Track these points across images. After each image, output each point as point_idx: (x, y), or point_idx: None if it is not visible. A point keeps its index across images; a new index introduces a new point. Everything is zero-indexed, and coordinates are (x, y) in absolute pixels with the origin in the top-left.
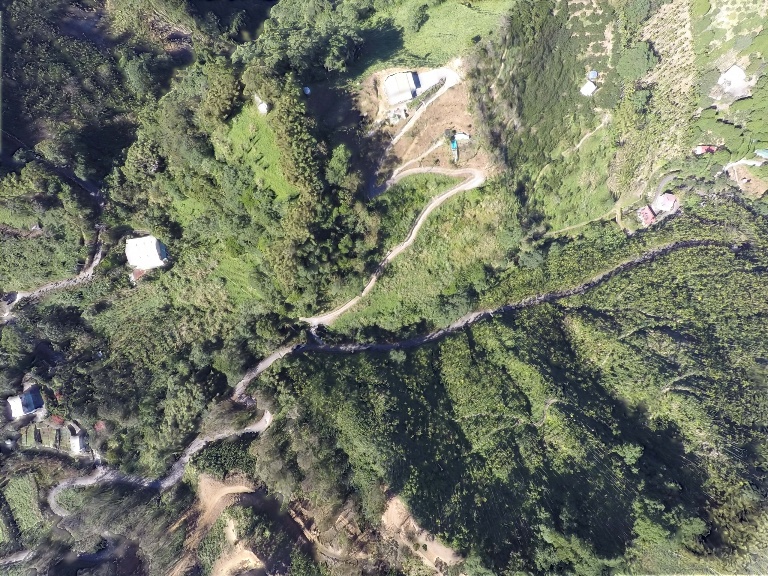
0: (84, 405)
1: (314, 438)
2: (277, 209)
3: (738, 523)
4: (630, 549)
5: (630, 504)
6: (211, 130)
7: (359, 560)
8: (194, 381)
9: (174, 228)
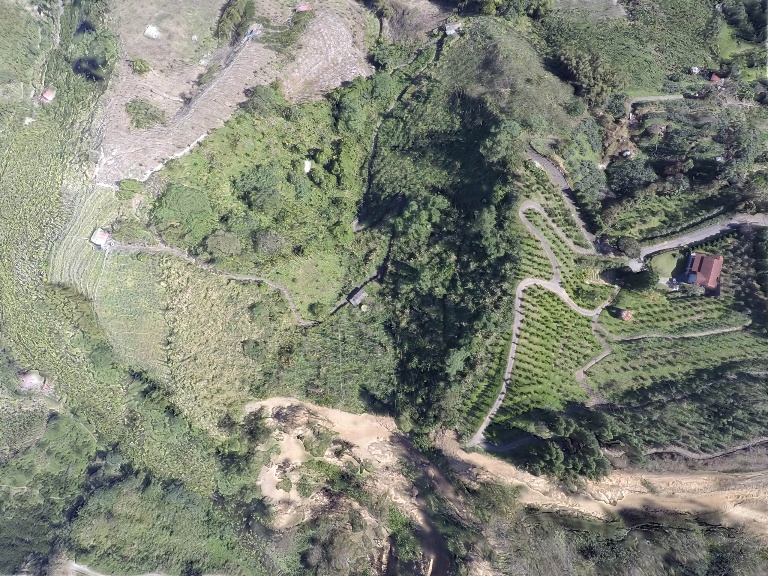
0: None
1: None
2: None
3: None
4: None
5: None
6: None
7: None
8: None
9: None
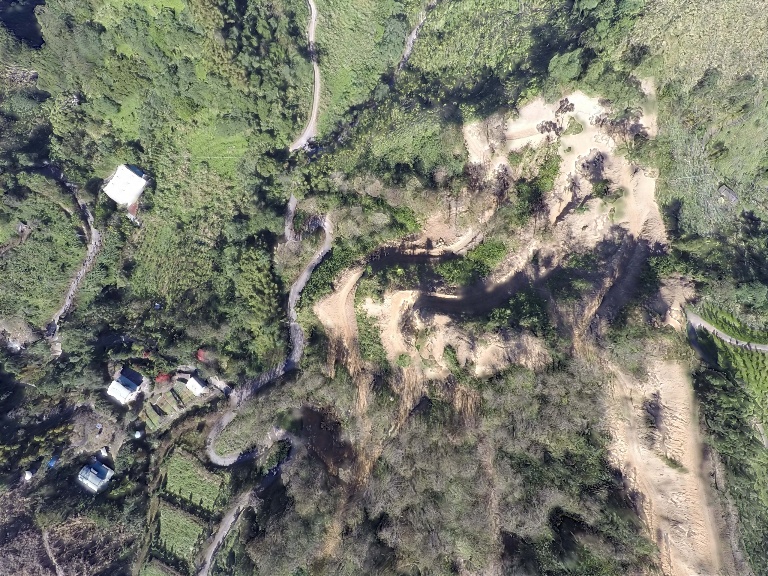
0: (174, 342)
1: None
2: (183, 20)
3: None
4: None
5: None
6: (88, 11)
7: (490, 219)
8: (246, 249)
9: None
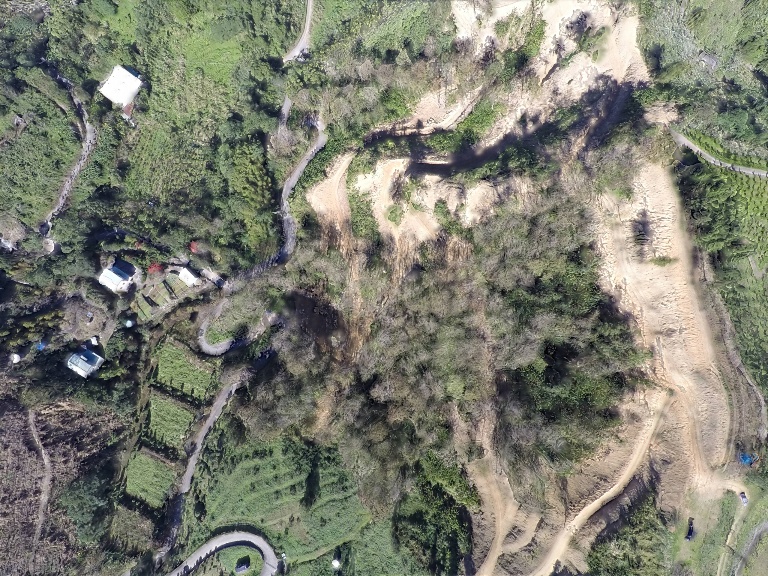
0: (167, 232)
1: None
2: None
3: None
4: None
5: None
6: None
7: None
8: (240, 146)
9: None
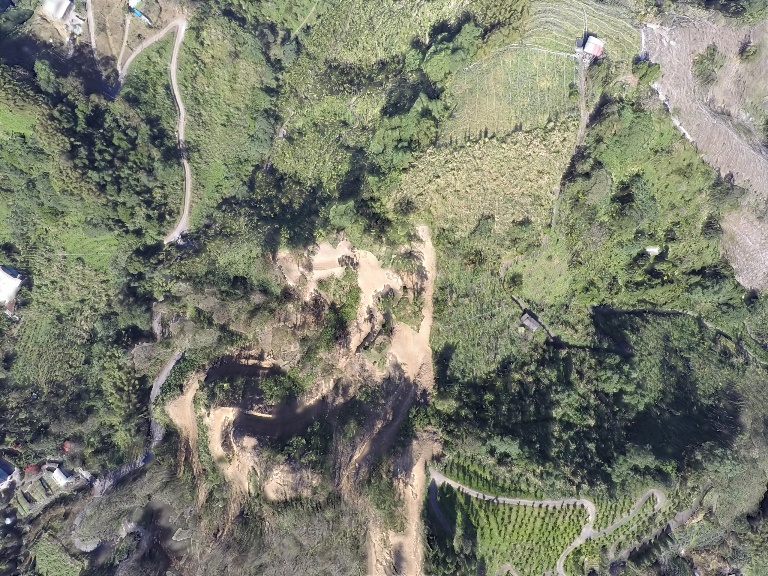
0: (40, 436)
1: (211, 290)
2: (33, 144)
3: (499, 8)
4: (439, 97)
5: (427, 81)
6: None
7: None
8: (111, 346)
9: (7, 247)
